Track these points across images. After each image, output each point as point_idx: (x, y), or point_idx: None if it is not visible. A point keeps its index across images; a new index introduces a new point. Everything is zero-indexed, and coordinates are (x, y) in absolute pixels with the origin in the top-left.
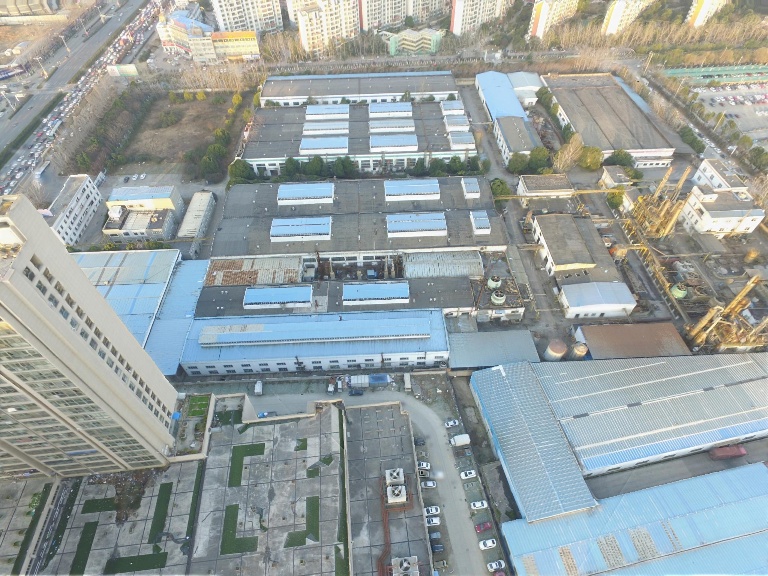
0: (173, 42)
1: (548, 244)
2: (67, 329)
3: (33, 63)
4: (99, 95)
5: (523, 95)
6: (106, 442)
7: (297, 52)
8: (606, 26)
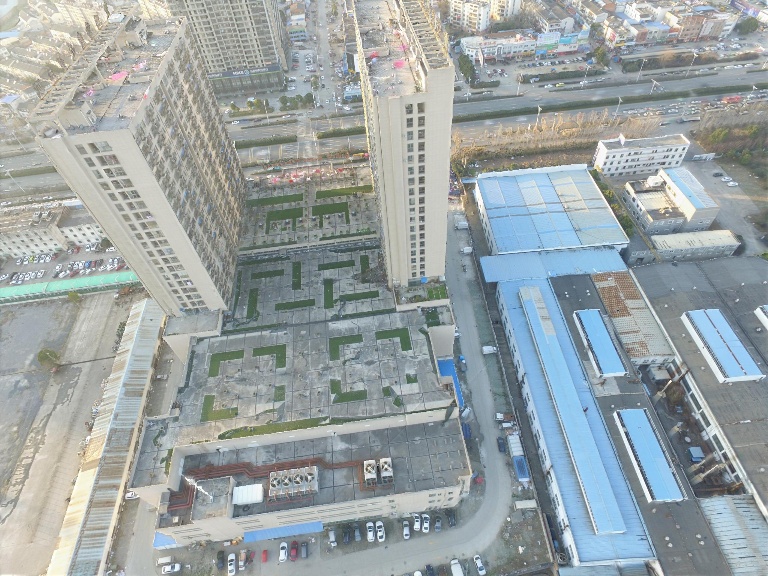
0: None
1: None
2: (400, 155)
3: None
4: None
5: None
6: None
7: None
8: None
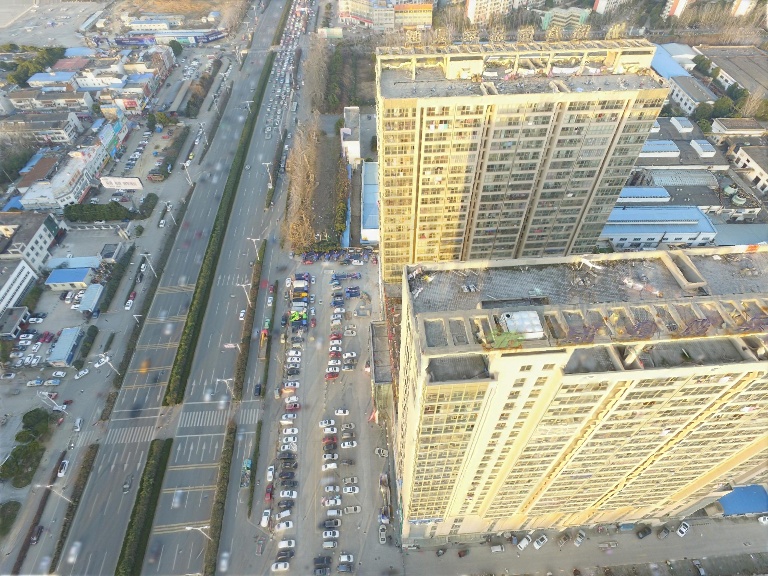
0: (349, 14)
1: (761, 166)
2: None
3: (234, 28)
4: (320, 51)
5: (683, 61)
6: (578, 241)
7: (469, 23)
8: (736, 8)
